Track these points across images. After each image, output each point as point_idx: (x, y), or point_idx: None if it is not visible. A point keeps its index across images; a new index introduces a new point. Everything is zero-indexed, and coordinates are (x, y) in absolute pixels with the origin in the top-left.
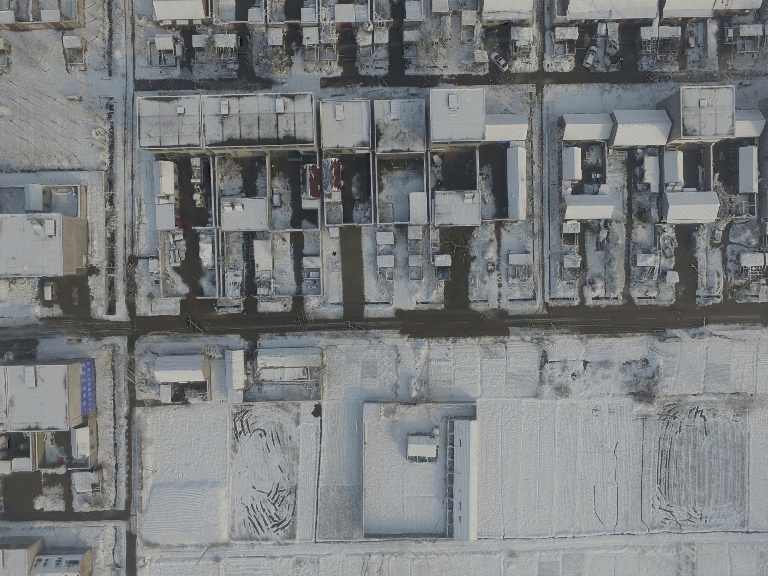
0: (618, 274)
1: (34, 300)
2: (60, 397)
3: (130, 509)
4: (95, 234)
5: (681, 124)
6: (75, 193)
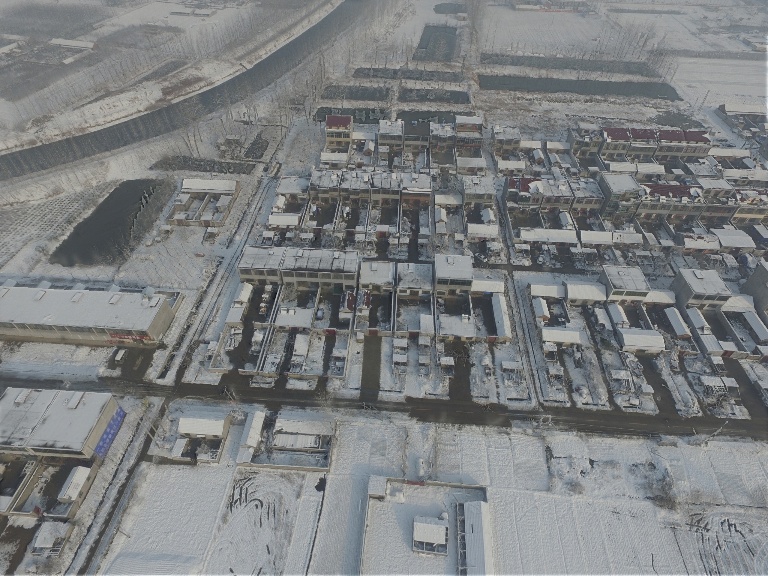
0: (599, 386)
1: (103, 363)
2: (91, 419)
3: None
4: (176, 324)
5: (610, 282)
6: (176, 297)
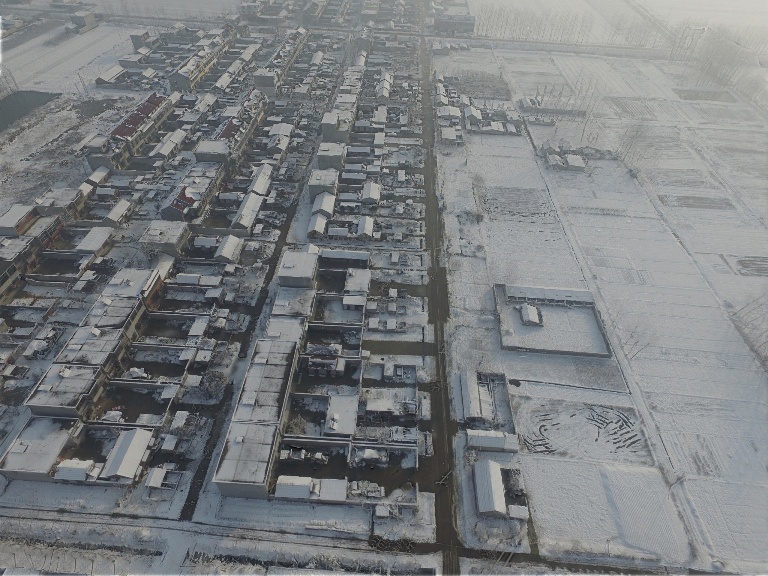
0: None
1: None
2: None
3: (661, 575)
4: None
5: (328, 186)
6: None
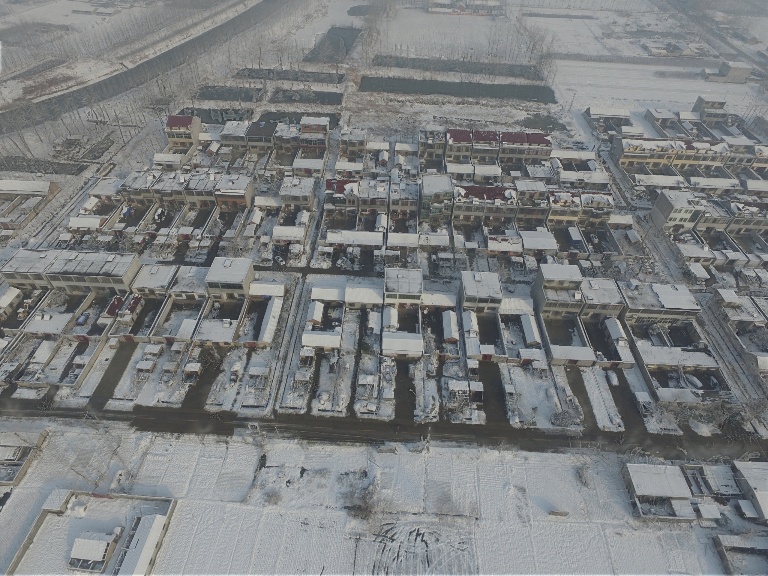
0: (344, 391)
1: None
2: None
3: None
4: None
5: (384, 285)
6: None
